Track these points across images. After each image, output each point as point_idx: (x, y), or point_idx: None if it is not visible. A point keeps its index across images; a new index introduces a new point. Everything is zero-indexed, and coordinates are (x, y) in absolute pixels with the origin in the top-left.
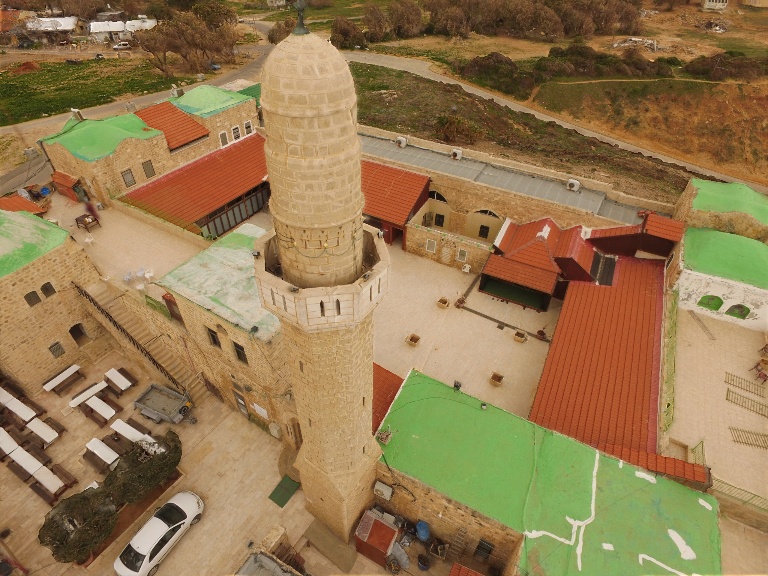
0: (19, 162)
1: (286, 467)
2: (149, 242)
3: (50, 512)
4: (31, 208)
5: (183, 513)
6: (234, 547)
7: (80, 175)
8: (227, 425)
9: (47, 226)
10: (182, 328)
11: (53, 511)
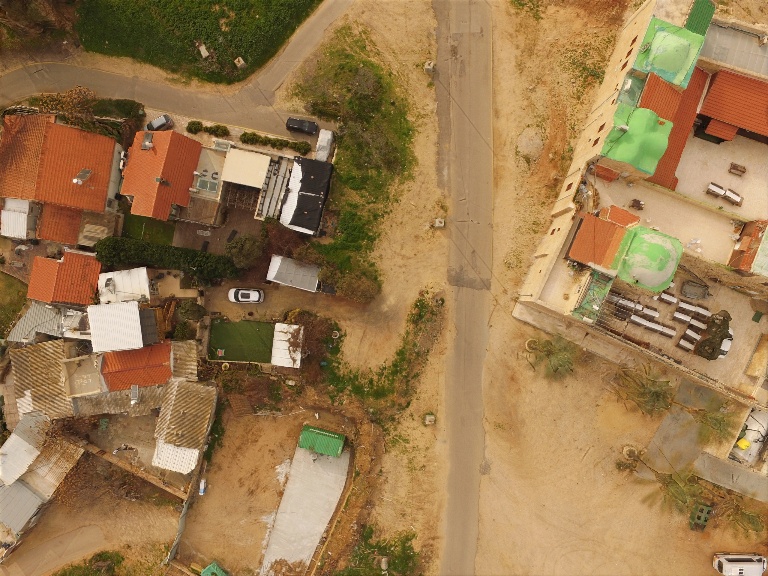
0: (427, 82)
1: (756, 308)
2: (677, 212)
3: (699, 348)
4: (631, 217)
5: (731, 335)
6: (746, 339)
7: (626, 172)
8: (722, 293)
9: (667, 238)
10: (738, 275)
11: (700, 347)
